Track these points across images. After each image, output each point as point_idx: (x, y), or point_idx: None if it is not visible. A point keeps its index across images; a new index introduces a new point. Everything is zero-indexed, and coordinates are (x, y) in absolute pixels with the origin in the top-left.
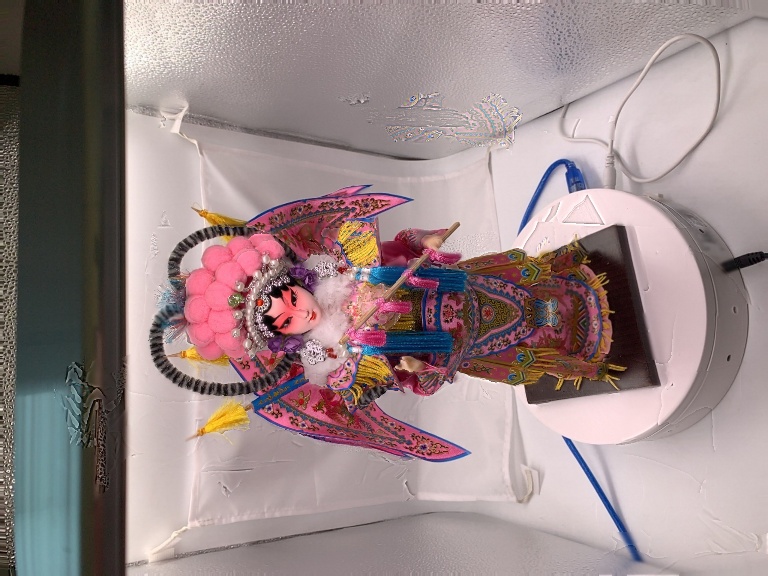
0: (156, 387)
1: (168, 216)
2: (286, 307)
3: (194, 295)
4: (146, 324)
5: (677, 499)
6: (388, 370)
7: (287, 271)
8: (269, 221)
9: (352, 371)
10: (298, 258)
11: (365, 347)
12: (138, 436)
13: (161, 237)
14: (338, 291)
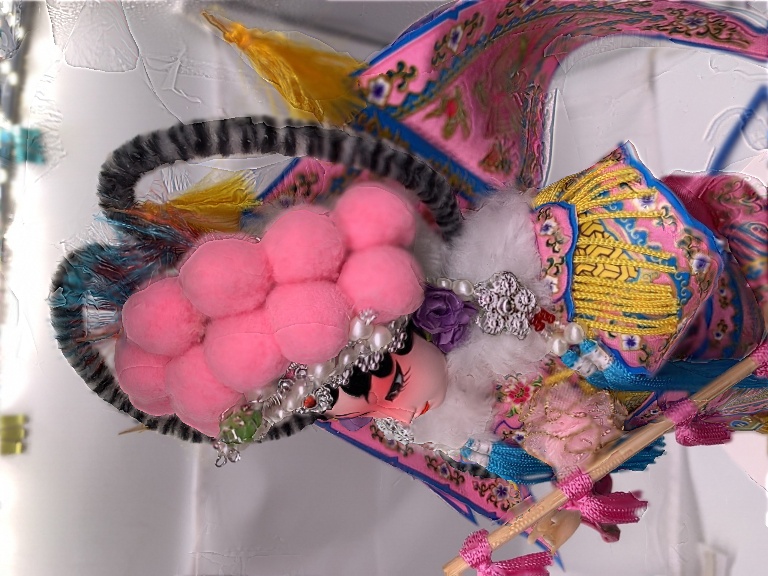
0: (58, 382)
1: (110, 35)
2: (368, 405)
3: (139, 350)
4: (42, 264)
5: (761, 518)
6: (514, 485)
7: (408, 319)
8: (432, 55)
9: (450, 456)
10: (457, 212)
11: (496, 466)
12: (38, 377)
13: (78, 107)
14: (505, 363)
